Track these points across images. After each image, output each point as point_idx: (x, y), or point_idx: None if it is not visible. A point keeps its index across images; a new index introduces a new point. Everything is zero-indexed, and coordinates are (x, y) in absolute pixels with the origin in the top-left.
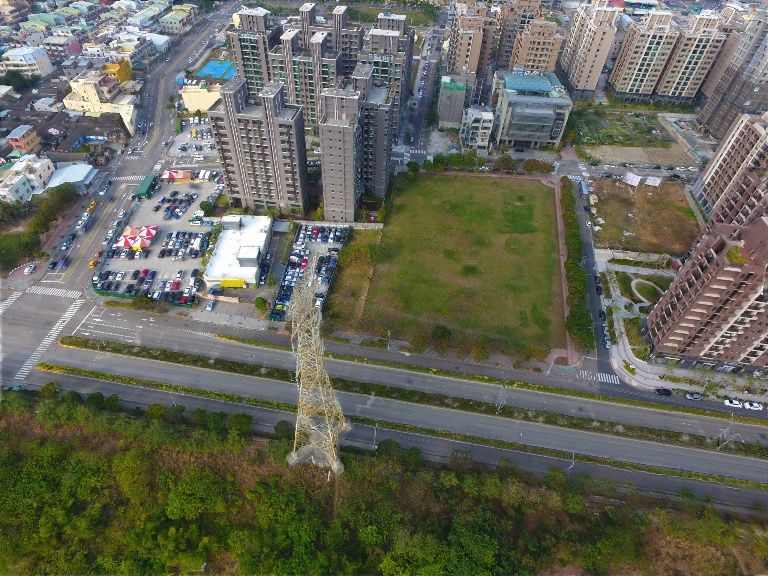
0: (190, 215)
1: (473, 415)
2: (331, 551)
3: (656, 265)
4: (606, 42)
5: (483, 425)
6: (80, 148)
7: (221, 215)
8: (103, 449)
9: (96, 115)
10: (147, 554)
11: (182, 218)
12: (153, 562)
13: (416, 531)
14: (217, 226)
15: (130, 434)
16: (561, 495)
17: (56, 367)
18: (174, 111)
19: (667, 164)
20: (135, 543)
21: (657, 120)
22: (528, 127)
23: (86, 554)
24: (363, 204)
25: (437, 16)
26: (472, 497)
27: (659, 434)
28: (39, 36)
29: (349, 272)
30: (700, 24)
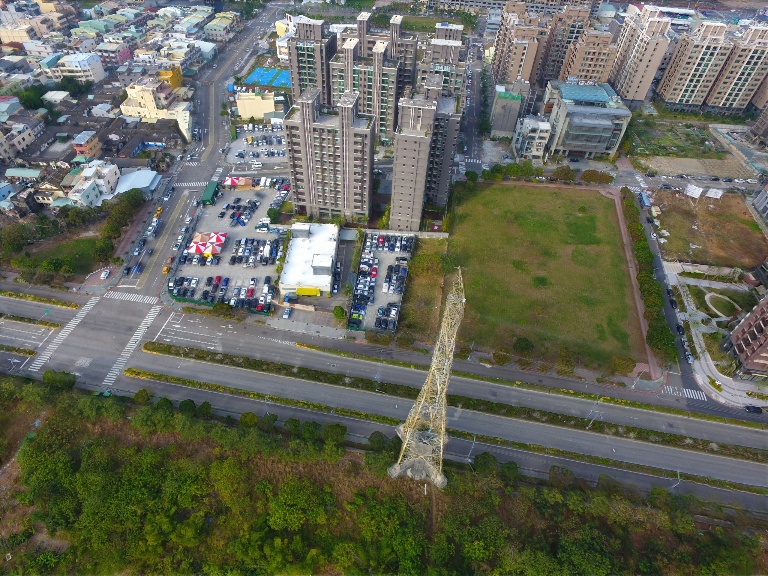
0: (255, 222)
1: (563, 429)
2: (440, 566)
3: (728, 279)
4: (659, 53)
5: (574, 440)
6: (141, 154)
7: (286, 222)
8: (198, 457)
9: (152, 121)
10: (253, 565)
11: (248, 225)
12: (259, 573)
13: (524, 548)
14: (284, 233)
15: (226, 442)
16: (667, 514)
17: (143, 373)
18: (227, 118)
19: (724, 176)
20: (242, 553)
21: (708, 131)
22: (585, 137)
23: (191, 563)
24: (425, 213)
25: (475, 25)
26: (577, 514)
27: (755, 453)
28: (91, 42)
29: (419, 281)
30: (755, 35)
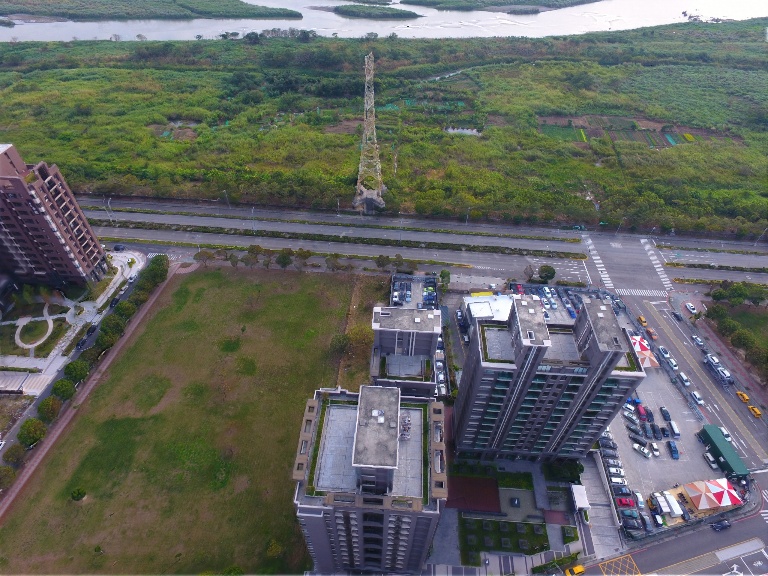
0: None
1: None
2: None
3: None
4: None
5: (268, 227)
6: None
7: None
8: None
9: None
10: None
11: None
12: None
13: None
14: None
15: None
16: None
17: (568, 240)
18: None
19: None
20: None
21: None
22: None
23: None
24: None
25: None
26: None
27: (150, 225)
28: None
29: None
30: None
